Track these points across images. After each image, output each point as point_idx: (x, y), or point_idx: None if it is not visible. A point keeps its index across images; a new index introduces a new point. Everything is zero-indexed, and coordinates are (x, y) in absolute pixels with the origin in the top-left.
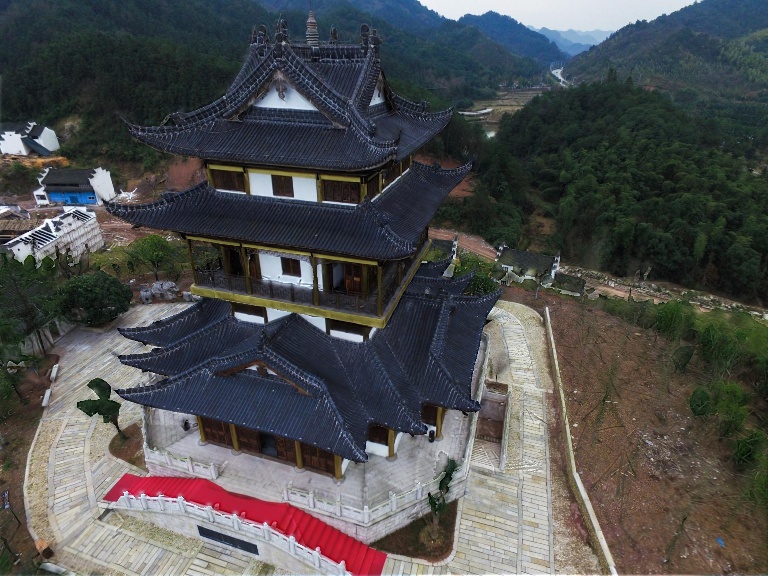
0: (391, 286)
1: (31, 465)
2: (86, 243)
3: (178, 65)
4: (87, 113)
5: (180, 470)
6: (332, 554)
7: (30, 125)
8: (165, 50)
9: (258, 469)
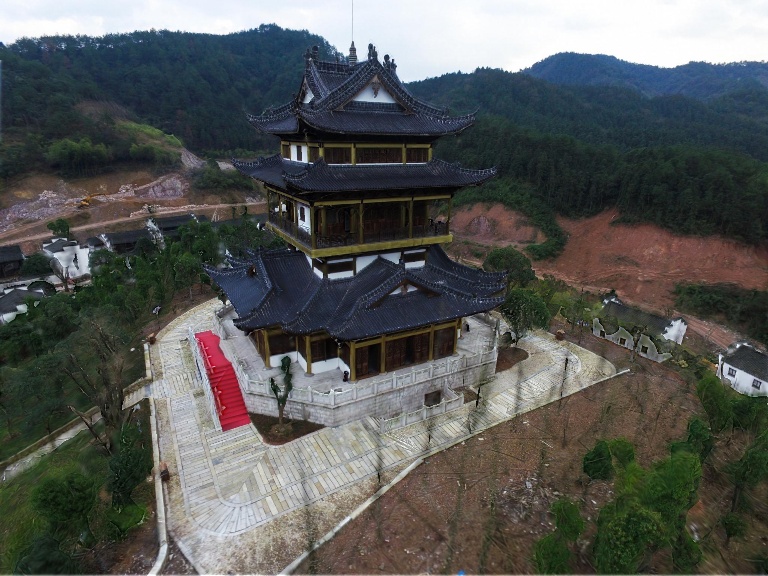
0: (342, 236)
1: (189, 312)
2: None
3: (499, 136)
4: None
5: (217, 330)
6: (224, 400)
7: None
8: (494, 124)
9: (243, 345)
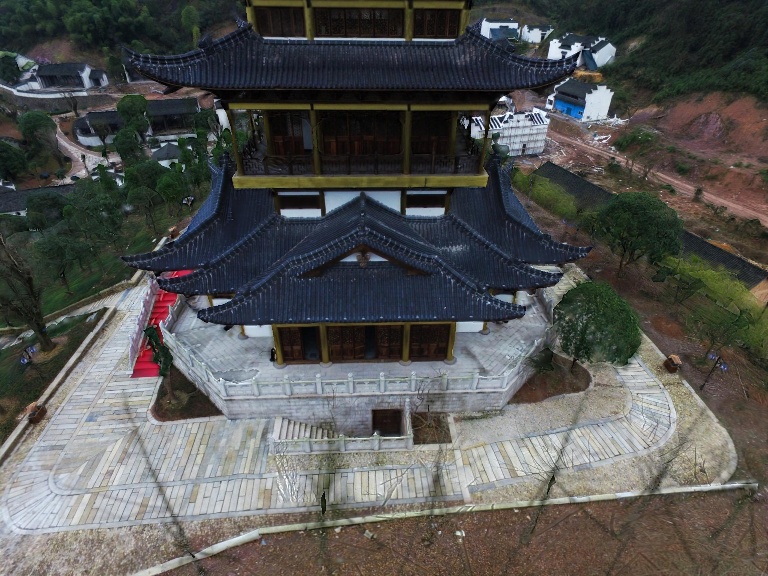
0: None
1: None
2: (525, 143)
3: None
4: (654, 34)
5: None
6: None
7: (599, 40)
8: None
9: None
